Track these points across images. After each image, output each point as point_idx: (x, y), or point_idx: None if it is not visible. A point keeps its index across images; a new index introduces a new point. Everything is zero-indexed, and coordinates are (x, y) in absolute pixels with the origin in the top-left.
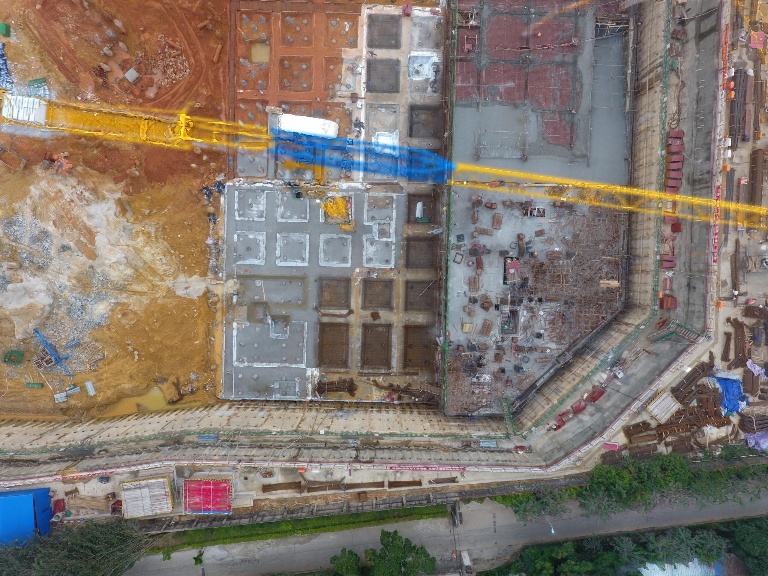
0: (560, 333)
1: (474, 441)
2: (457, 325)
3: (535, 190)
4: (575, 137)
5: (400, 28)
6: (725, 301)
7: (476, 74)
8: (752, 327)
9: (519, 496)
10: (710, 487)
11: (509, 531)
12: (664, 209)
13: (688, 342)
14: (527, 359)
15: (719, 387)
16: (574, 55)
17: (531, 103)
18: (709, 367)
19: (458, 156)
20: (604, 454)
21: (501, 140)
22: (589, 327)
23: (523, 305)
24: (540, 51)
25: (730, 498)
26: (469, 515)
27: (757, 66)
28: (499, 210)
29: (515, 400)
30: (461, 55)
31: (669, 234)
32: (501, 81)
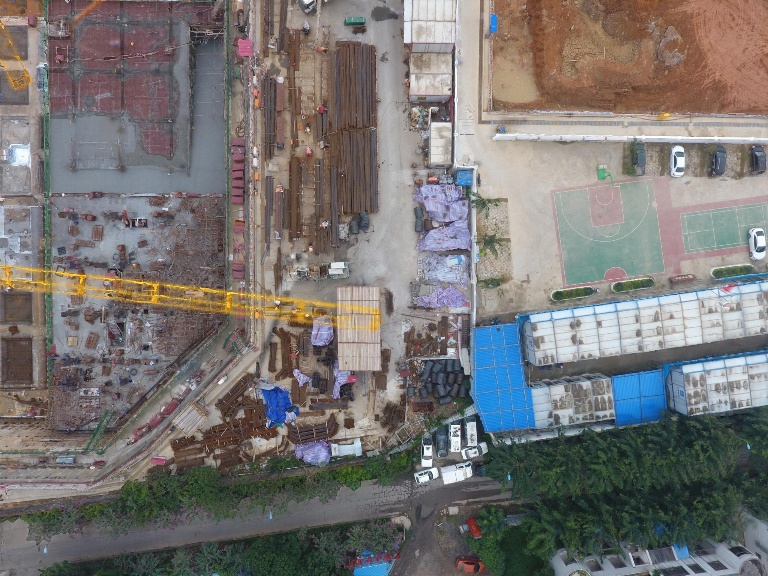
0: (168, 345)
1: (53, 457)
2: (63, 339)
3: (136, 201)
4: (175, 146)
5: (27, 39)
6: (270, 311)
7: (71, 85)
8: (297, 337)
9: (46, 514)
10: (212, 502)
11: (53, 549)
12: (236, 218)
13: (235, 353)
14: (135, 372)
15: (262, 398)
16: (170, 64)
17: (128, 113)
18: (253, 378)
19: (55, 168)
20: (151, 469)
21: (97, 151)
22: (179, 339)
23: (129, 317)
24: (135, 60)
25: (280, 511)
26: (12, 534)
27: (290, 73)
28: (100, 222)
29: (125, 413)
30: (54, 66)
31: (239, 243)
32: (97, 91)
